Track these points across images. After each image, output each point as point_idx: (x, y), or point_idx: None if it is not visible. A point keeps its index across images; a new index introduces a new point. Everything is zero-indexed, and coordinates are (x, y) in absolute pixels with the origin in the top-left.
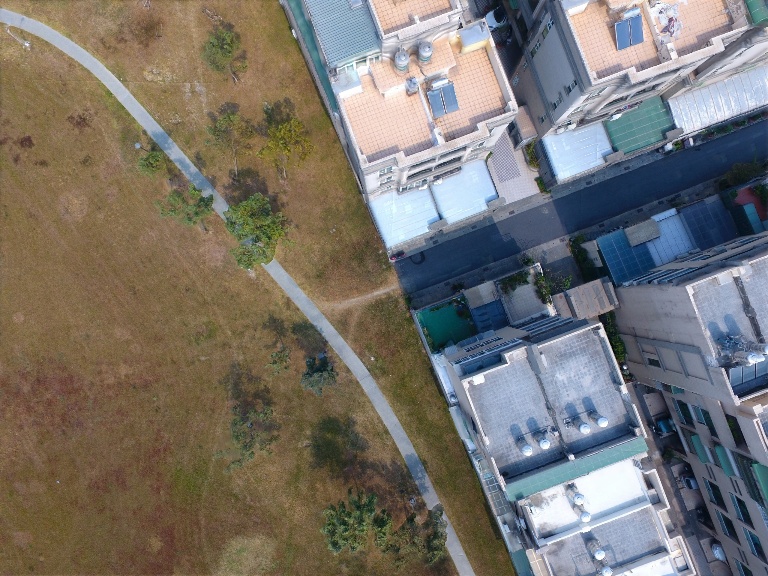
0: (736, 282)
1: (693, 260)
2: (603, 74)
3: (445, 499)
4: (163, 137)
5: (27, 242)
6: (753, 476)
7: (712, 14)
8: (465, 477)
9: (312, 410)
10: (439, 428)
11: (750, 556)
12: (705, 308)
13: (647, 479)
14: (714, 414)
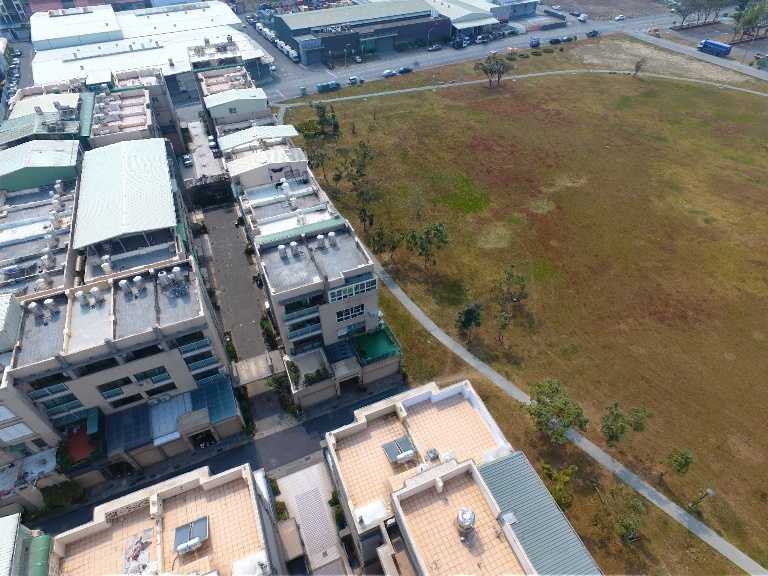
0: (160, 325)
1: (166, 379)
2: (229, 490)
3: None
4: (696, 529)
5: (766, 414)
6: None
7: (81, 571)
8: None
9: None
10: None
11: None
12: (189, 311)
13: None
14: None
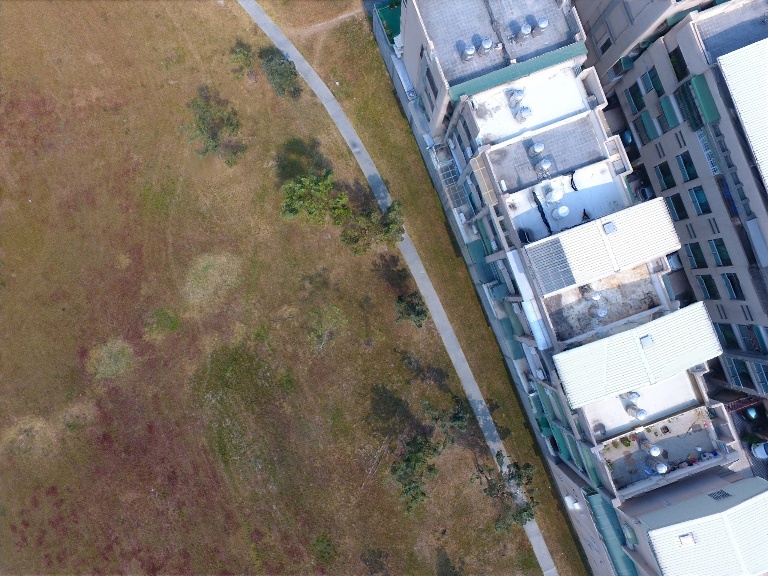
0: None
1: None
2: None
3: (407, 218)
4: None
5: None
6: (692, 95)
7: None
8: (426, 197)
9: (278, 132)
10: (401, 149)
11: (696, 222)
12: None
13: (587, 88)
14: (659, 60)
